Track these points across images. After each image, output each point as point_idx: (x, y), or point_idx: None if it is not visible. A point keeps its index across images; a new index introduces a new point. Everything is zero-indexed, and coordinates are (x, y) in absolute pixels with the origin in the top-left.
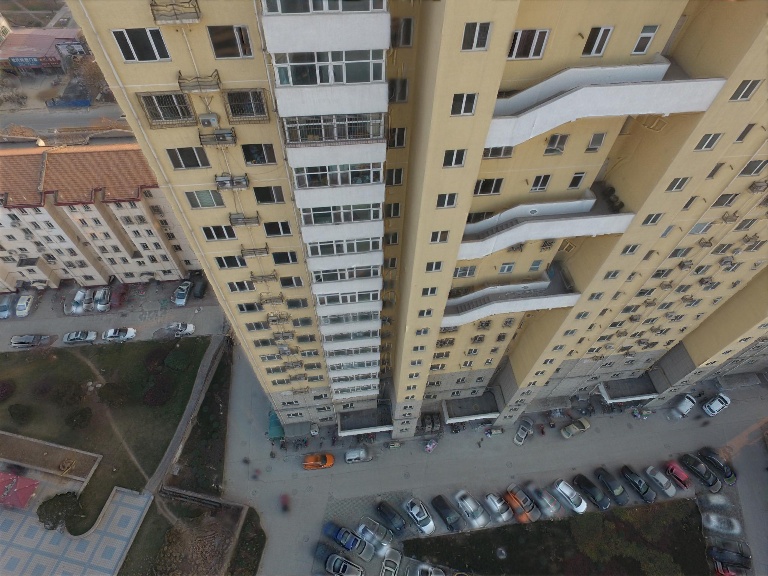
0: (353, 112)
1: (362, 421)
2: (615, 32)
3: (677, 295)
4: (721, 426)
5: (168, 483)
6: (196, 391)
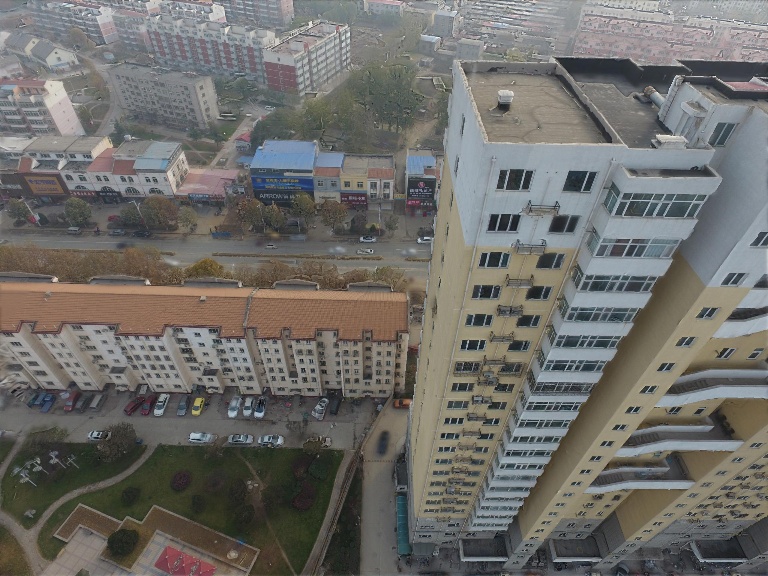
0: (577, 382)
1: (481, 549)
2: (738, 351)
3: (767, 482)
4: None
5: None
6: (334, 500)
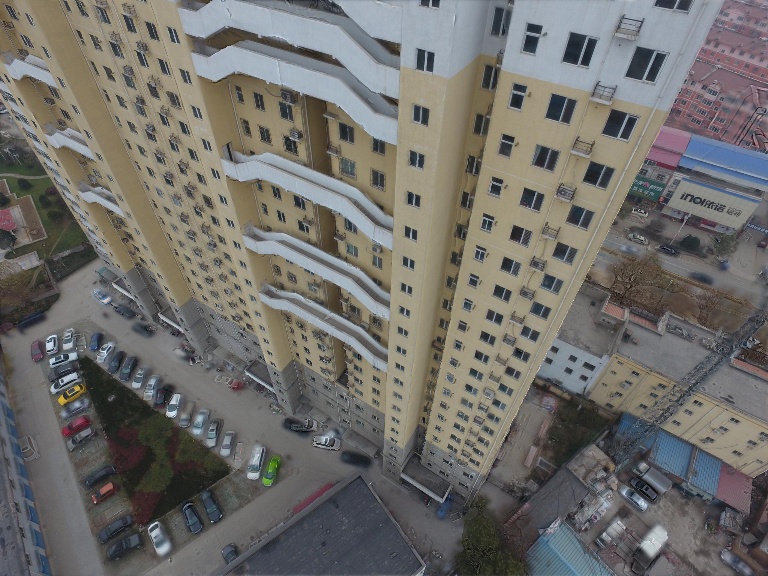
0: None
1: None
2: None
3: (218, 269)
4: (313, 457)
5: (46, 260)
6: None
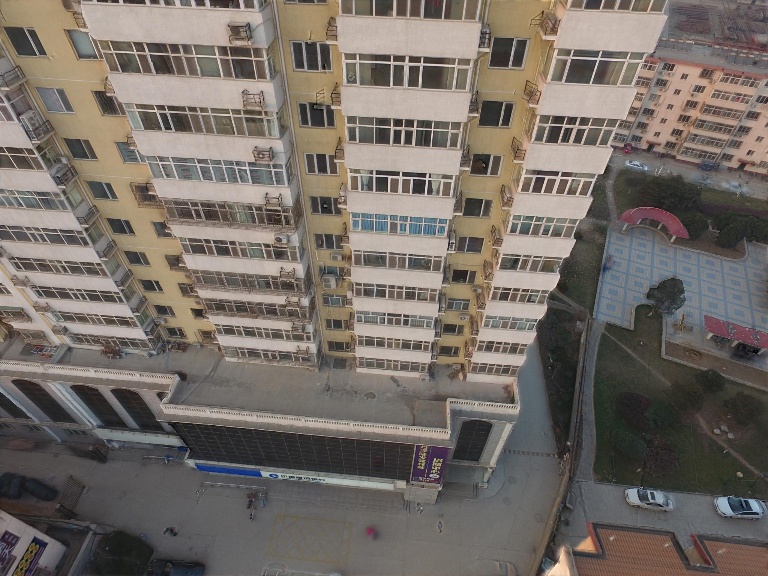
0: None
1: None
2: None
3: None
4: None
5: None
6: (589, 405)
